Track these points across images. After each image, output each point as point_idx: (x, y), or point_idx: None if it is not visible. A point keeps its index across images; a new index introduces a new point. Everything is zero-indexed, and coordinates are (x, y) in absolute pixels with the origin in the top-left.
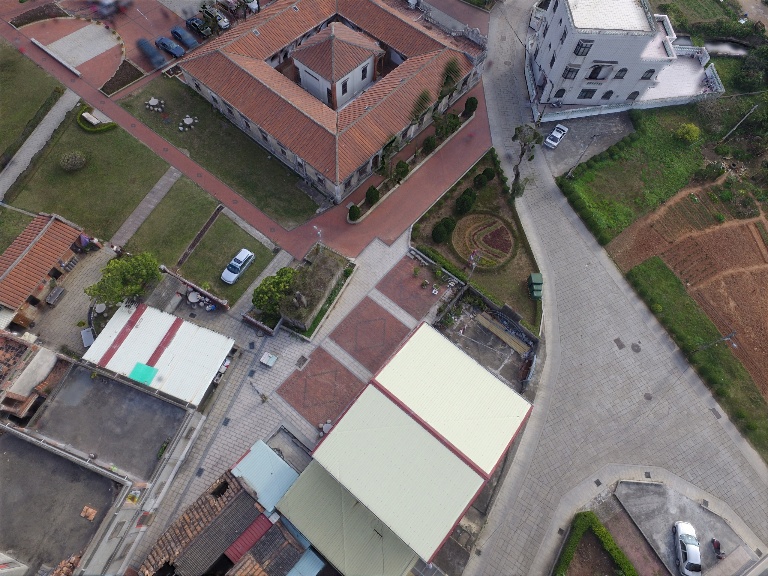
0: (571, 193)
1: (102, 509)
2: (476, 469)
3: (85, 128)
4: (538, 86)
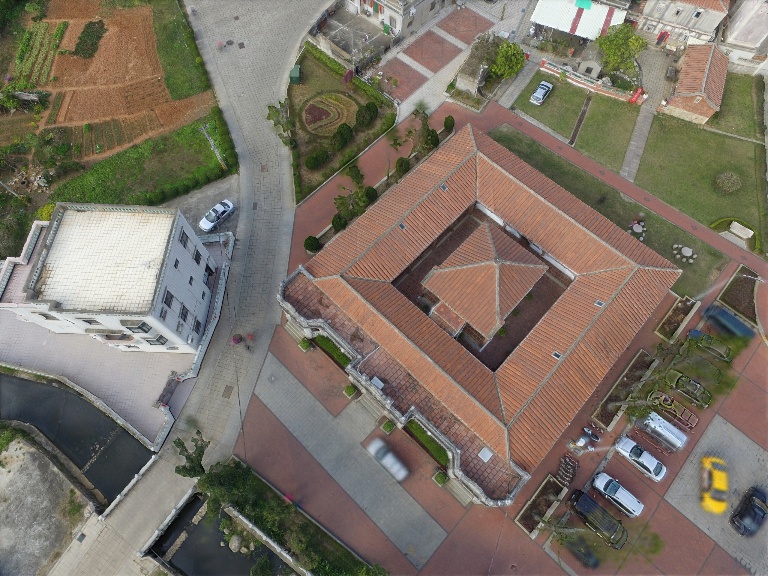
0: None
1: None
2: None
3: (741, 220)
4: (210, 292)
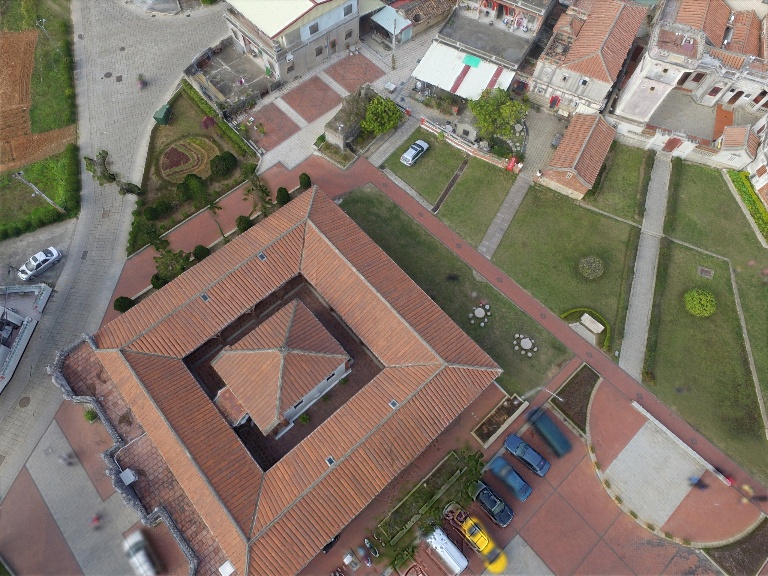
0: (73, 191)
1: None
2: None
3: None
4: (9, 348)
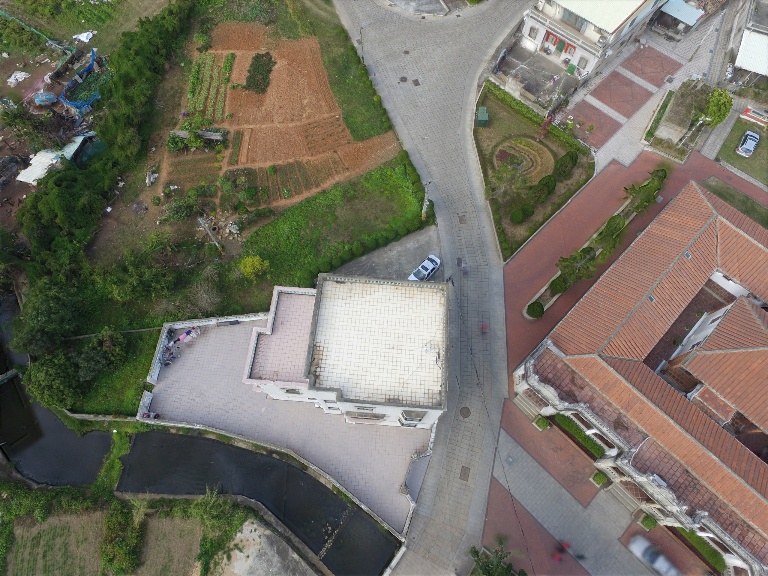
0: None
1: None
2: None
3: None
4: None
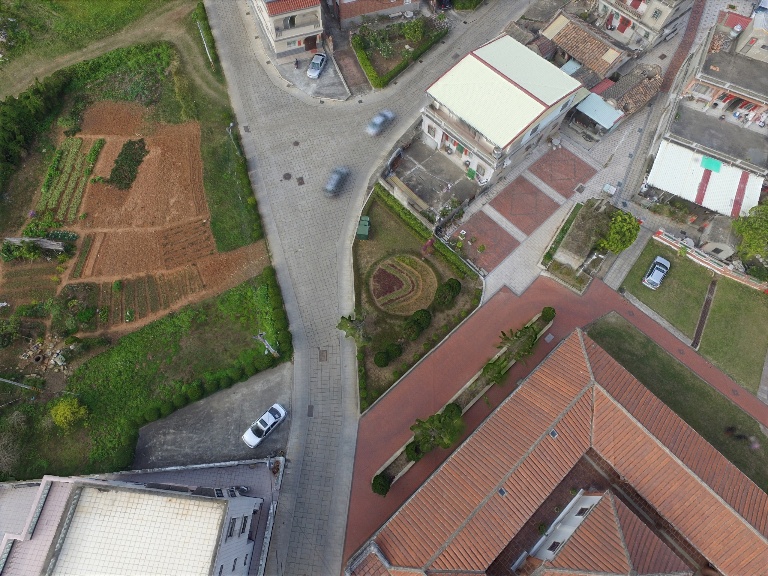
0: (284, 329)
1: (708, 69)
2: (477, 57)
3: None
4: (252, 540)
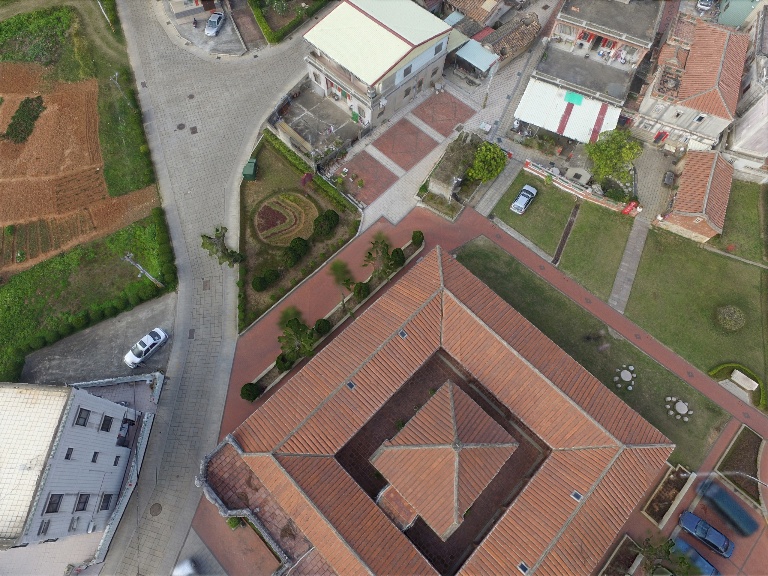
0: (169, 262)
1: (569, 10)
2: (352, 3)
3: None
4: (129, 448)
